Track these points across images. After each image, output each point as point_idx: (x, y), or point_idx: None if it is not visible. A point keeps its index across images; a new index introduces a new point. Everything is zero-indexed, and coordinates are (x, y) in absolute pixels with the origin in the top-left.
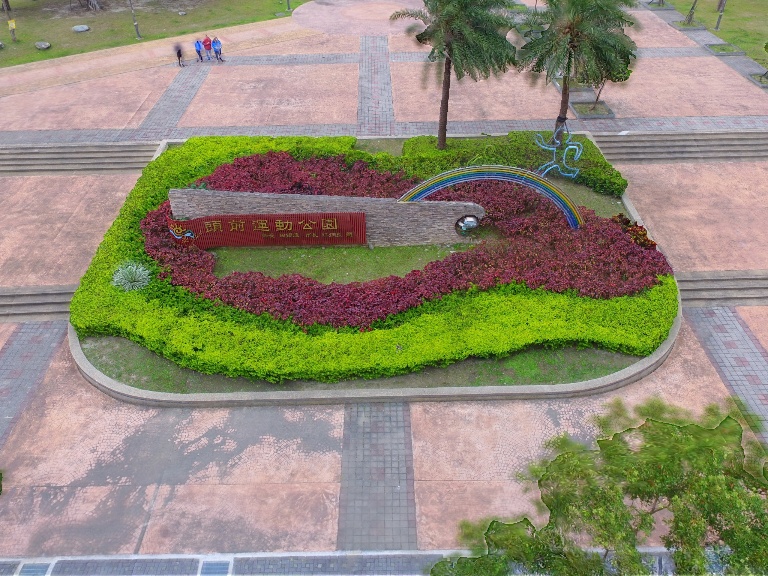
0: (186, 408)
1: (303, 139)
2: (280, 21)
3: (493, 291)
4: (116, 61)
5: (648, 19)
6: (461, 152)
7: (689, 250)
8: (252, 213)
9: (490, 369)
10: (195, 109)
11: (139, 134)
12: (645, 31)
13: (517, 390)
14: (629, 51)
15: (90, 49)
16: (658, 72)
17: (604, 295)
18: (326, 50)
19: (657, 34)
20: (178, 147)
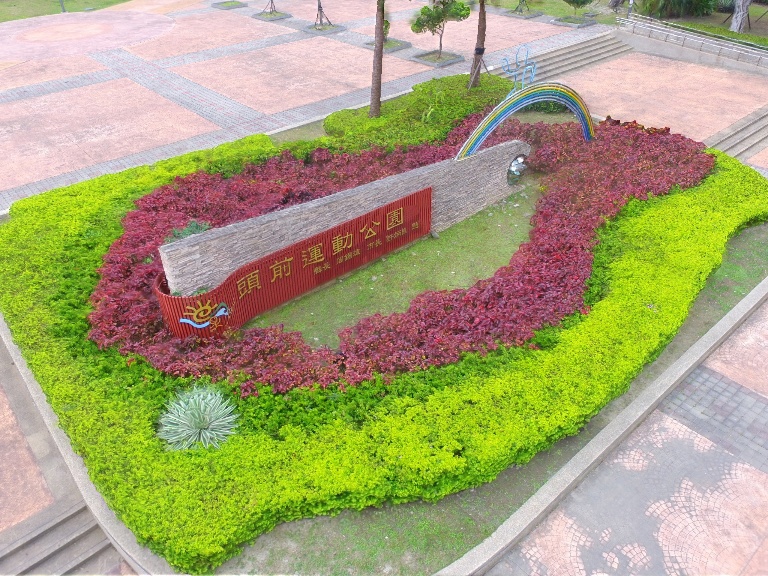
0: (507, 555)
1: (197, 155)
2: None
3: (621, 217)
4: None
5: None
6: (405, 112)
7: None
8: (297, 240)
9: (713, 289)
10: None
11: None
12: (375, 2)
13: (761, 293)
14: None
15: None
16: None
17: None
18: (59, 75)
19: (388, 2)
20: None
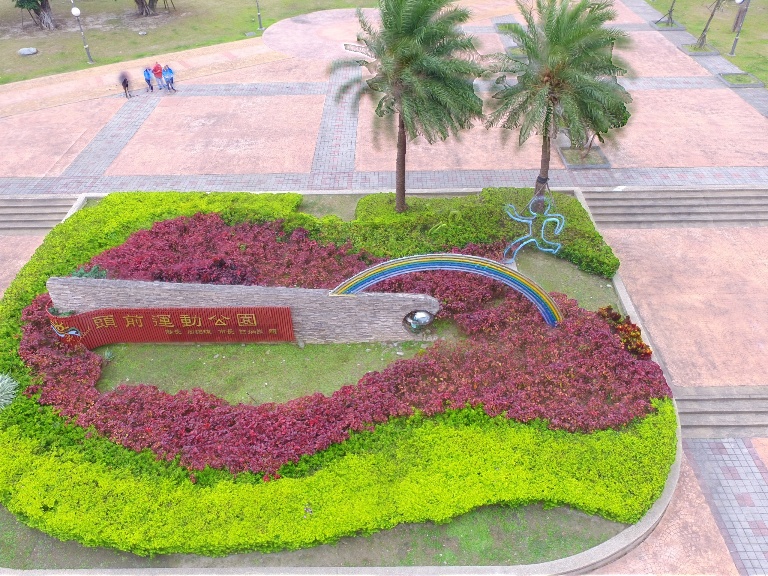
0: None
1: (240, 196)
2: (248, 42)
3: (441, 418)
4: (58, 90)
5: (655, 41)
6: (422, 217)
7: (693, 353)
8: (151, 306)
9: (427, 537)
10: (130, 152)
11: (59, 184)
12: (651, 56)
13: (459, 574)
14: (621, 106)
15: (34, 75)
16: (663, 108)
17: (582, 427)
18: (292, 78)
19: (664, 60)
20: (98, 203)
